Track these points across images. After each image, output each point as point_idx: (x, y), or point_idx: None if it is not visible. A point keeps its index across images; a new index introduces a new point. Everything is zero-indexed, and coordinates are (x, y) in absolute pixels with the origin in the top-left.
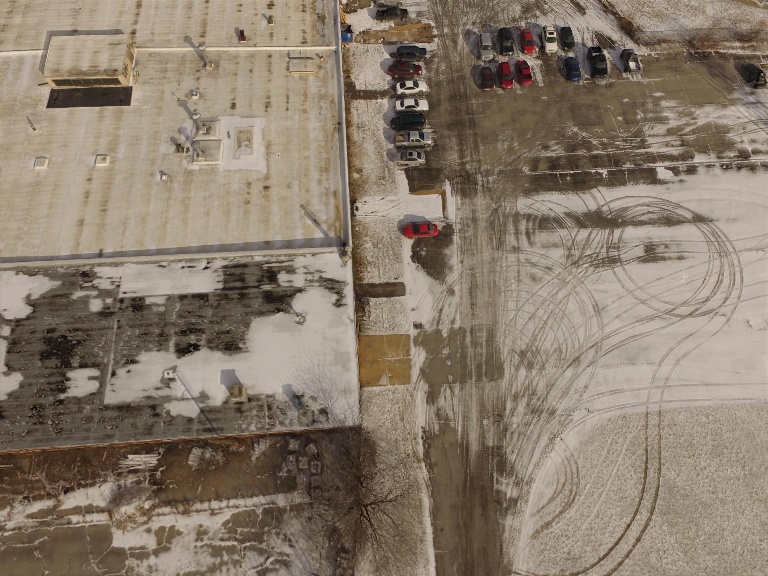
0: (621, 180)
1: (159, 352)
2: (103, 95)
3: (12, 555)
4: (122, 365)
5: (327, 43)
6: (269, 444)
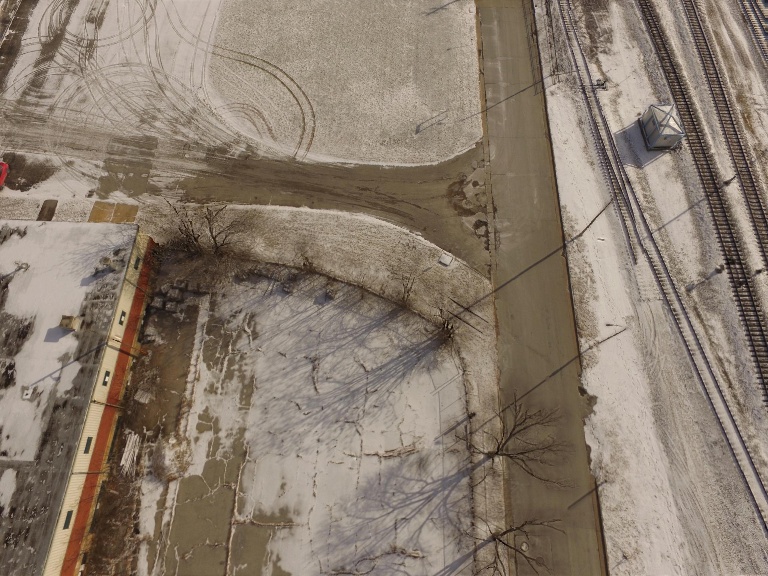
0: (23, 22)
1: None
2: None
3: None
4: None
5: None
6: (153, 328)
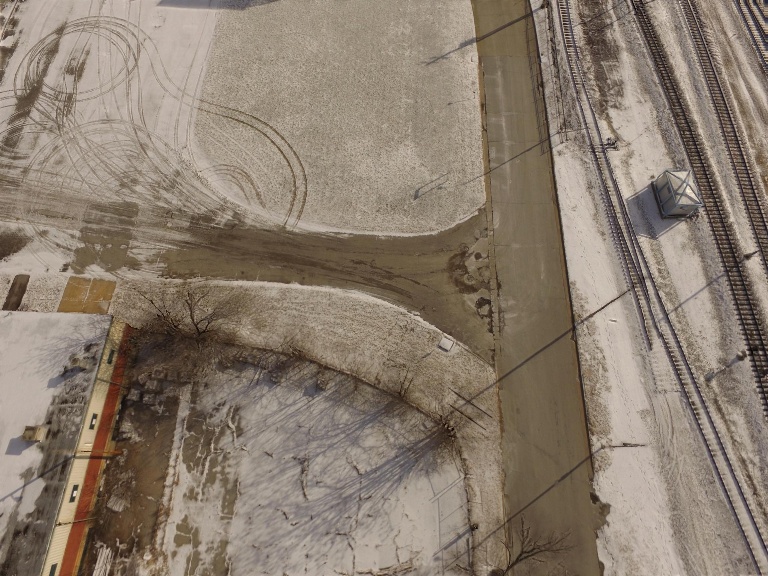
0: None
1: None
2: None
3: None
4: None
5: None
6: (129, 423)
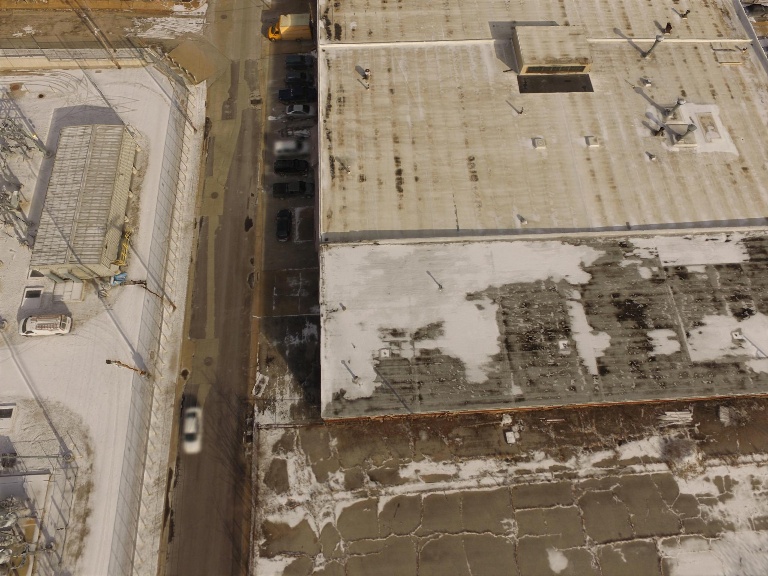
0: None
1: (720, 316)
2: (566, 82)
3: (594, 499)
4: (692, 327)
5: (741, 36)
6: None
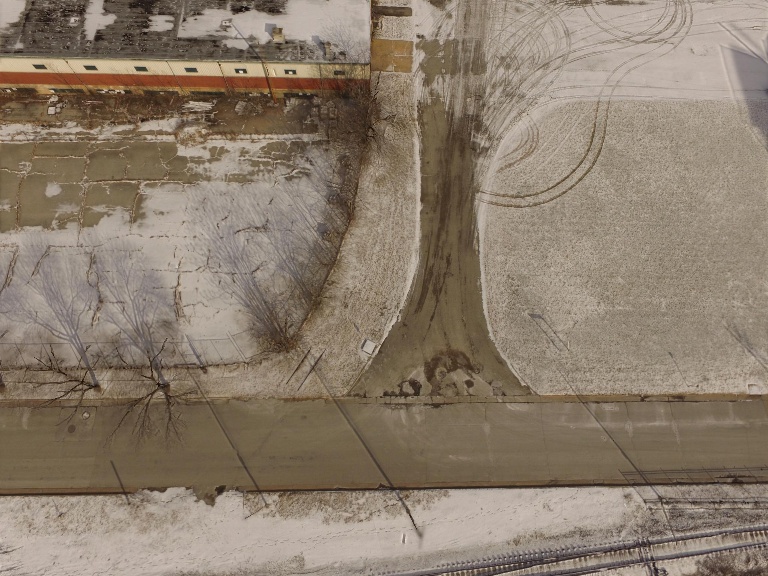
0: None
1: (219, 9)
2: None
3: (103, 155)
4: (191, 15)
5: None
6: (298, 103)
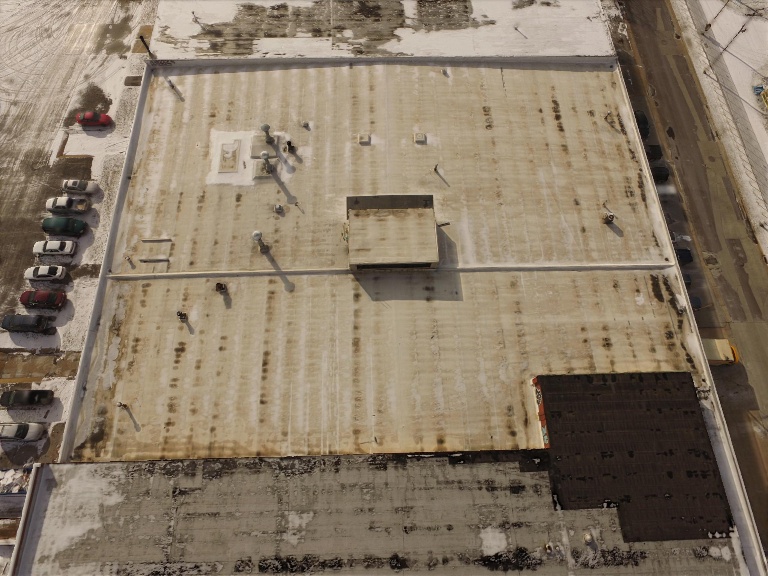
0: None
1: (299, 6)
2: None
3: None
4: (324, 1)
5: (117, 285)
6: None
